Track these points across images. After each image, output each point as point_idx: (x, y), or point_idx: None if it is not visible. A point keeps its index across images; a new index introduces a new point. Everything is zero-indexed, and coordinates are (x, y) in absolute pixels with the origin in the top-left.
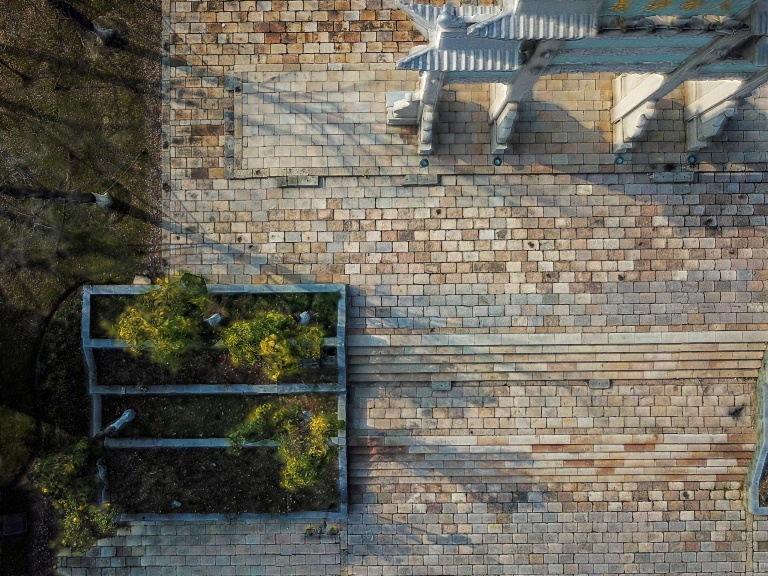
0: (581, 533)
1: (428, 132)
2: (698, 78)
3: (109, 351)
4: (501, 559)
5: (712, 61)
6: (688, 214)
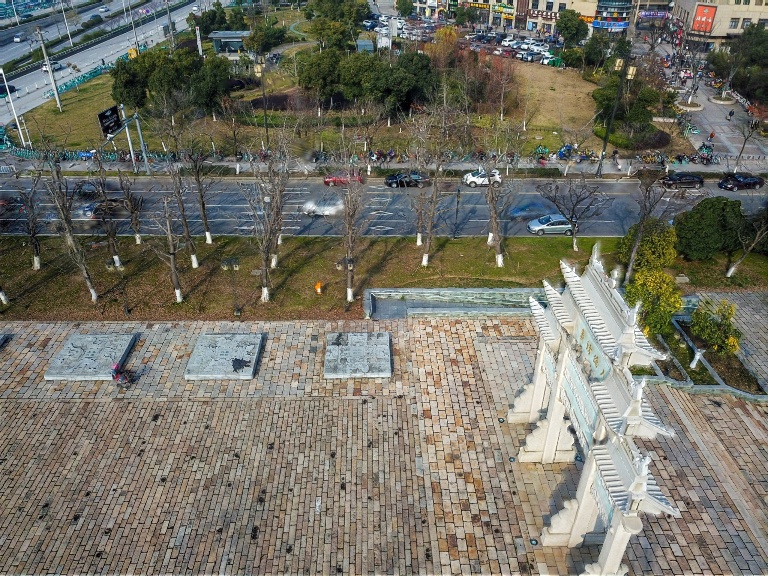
0: None
1: None
2: None
3: None
4: None
5: None
6: None
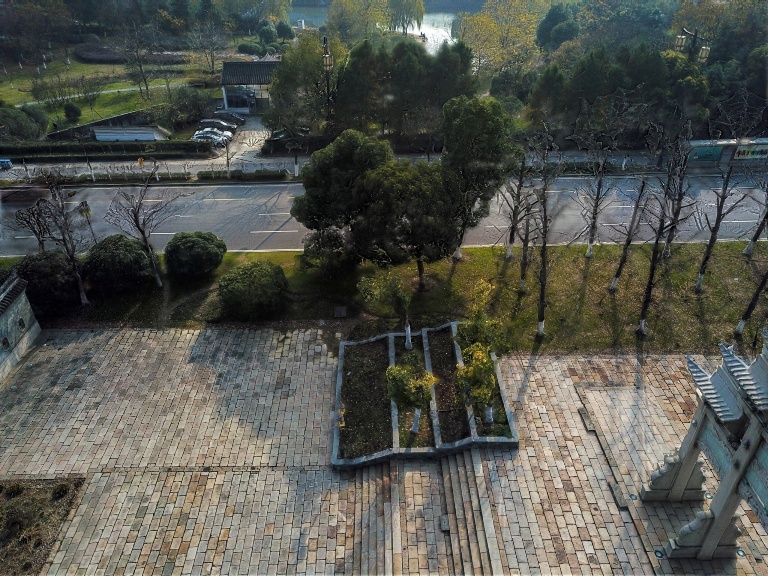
0: None
1: (659, 473)
2: None
3: (450, 331)
4: None
5: None
6: None
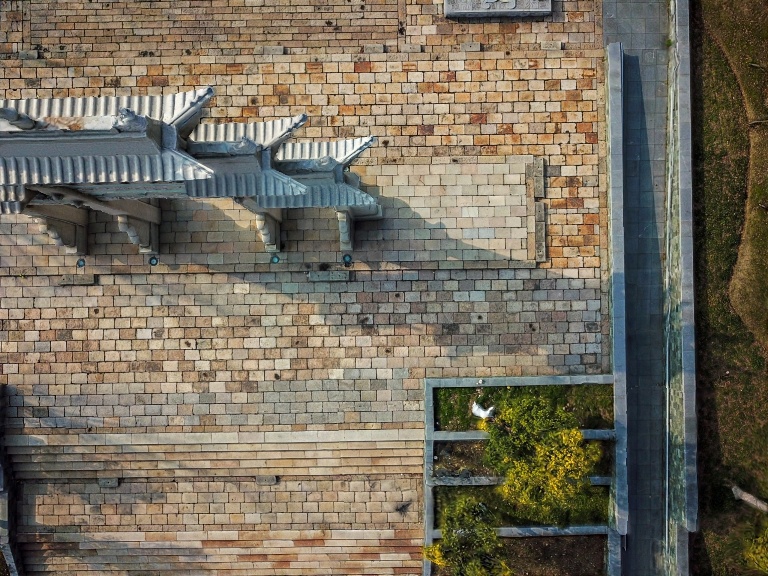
0: None
1: (57, 240)
2: None
3: None
4: None
5: None
6: (345, 312)
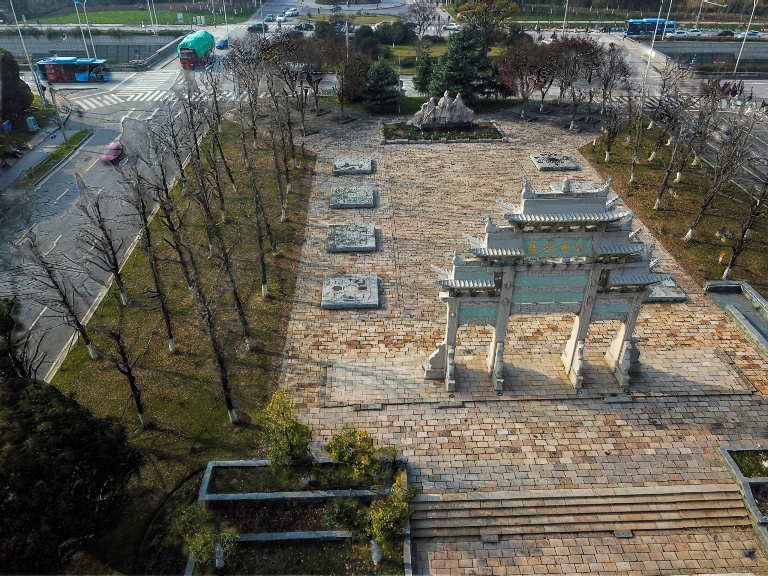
0: None
1: (452, 366)
2: (598, 318)
3: (219, 502)
4: None
5: (595, 294)
6: (638, 418)
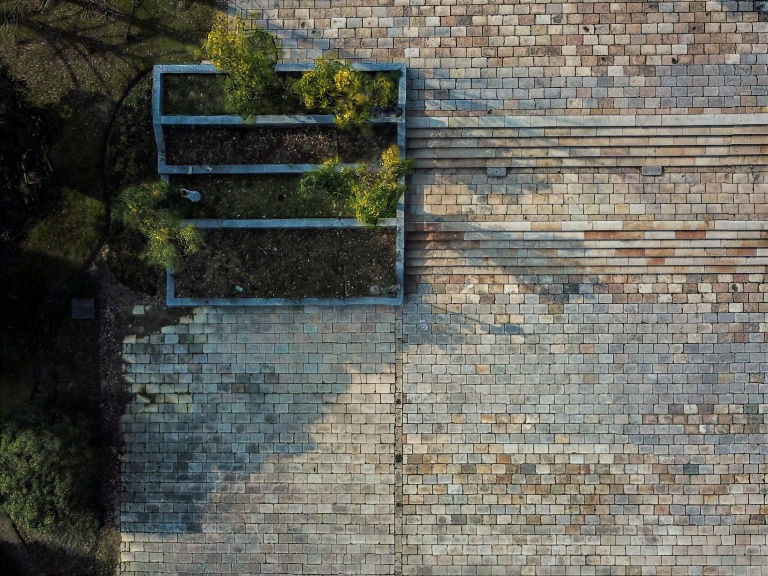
0: (631, 324)
1: None
2: None
3: (178, 128)
4: (552, 349)
5: None
6: None
